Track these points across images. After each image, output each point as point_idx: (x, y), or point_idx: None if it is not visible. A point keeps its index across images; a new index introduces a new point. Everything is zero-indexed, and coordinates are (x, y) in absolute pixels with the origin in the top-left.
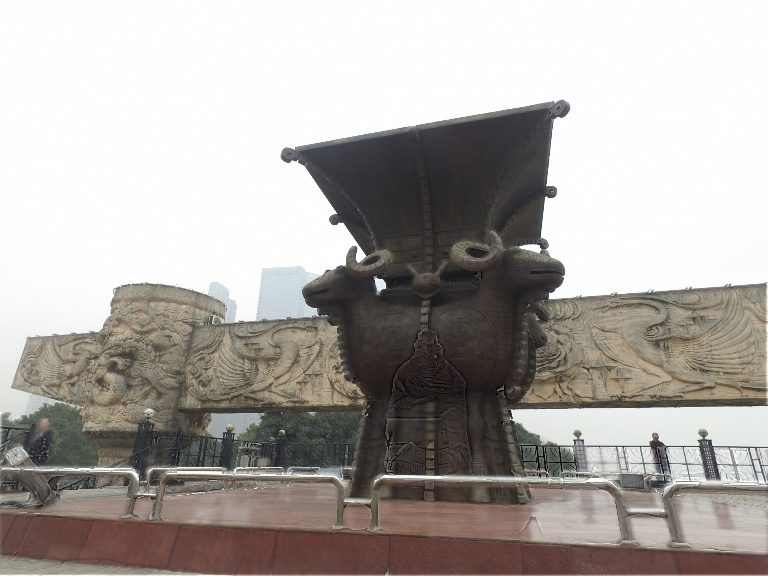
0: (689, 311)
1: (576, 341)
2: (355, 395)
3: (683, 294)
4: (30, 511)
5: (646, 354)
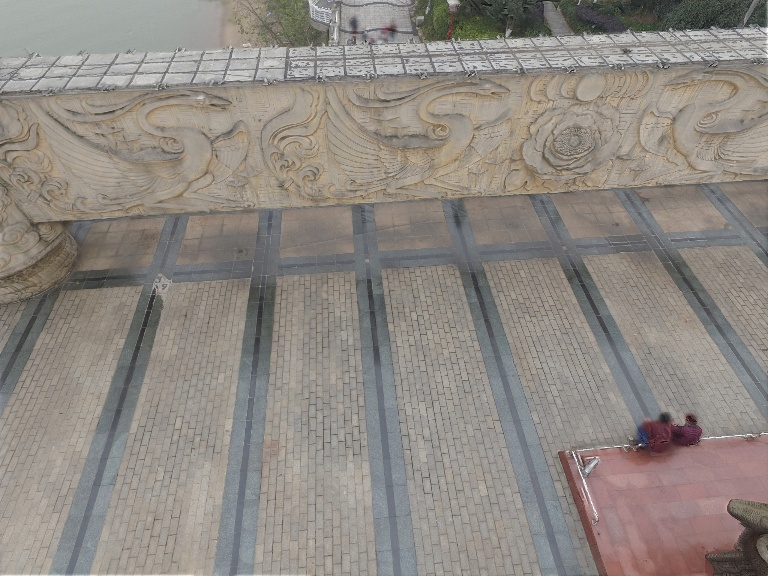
0: None
1: None
2: None
3: None
4: None
5: None
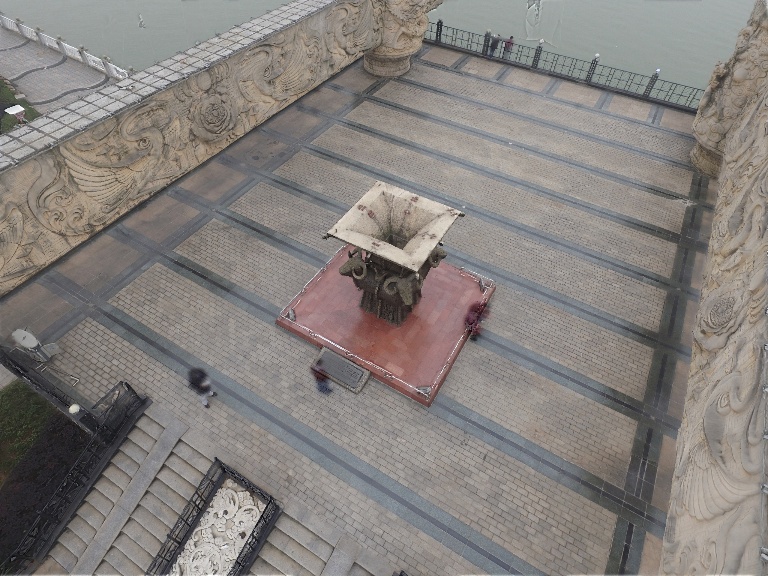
0: (280, 49)
1: (231, 96)
2: (92, 228)
3: (277, 35)
4: (434, 387)
5: (266, 91)
